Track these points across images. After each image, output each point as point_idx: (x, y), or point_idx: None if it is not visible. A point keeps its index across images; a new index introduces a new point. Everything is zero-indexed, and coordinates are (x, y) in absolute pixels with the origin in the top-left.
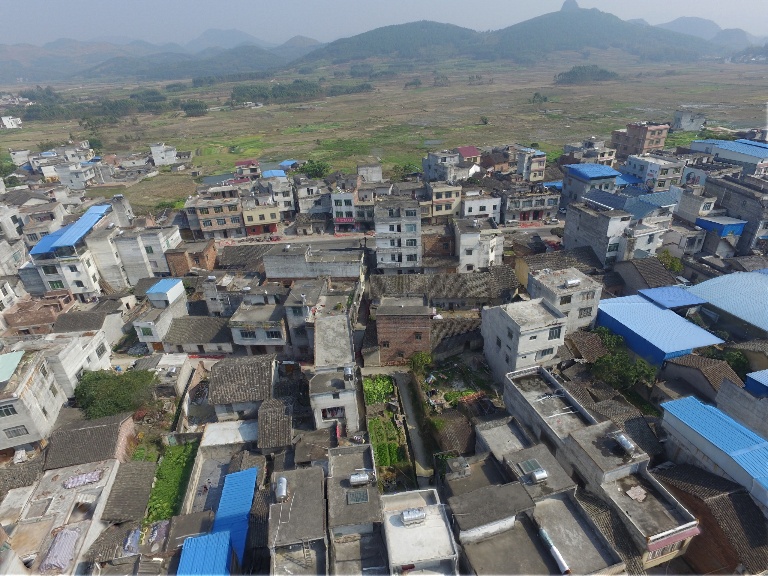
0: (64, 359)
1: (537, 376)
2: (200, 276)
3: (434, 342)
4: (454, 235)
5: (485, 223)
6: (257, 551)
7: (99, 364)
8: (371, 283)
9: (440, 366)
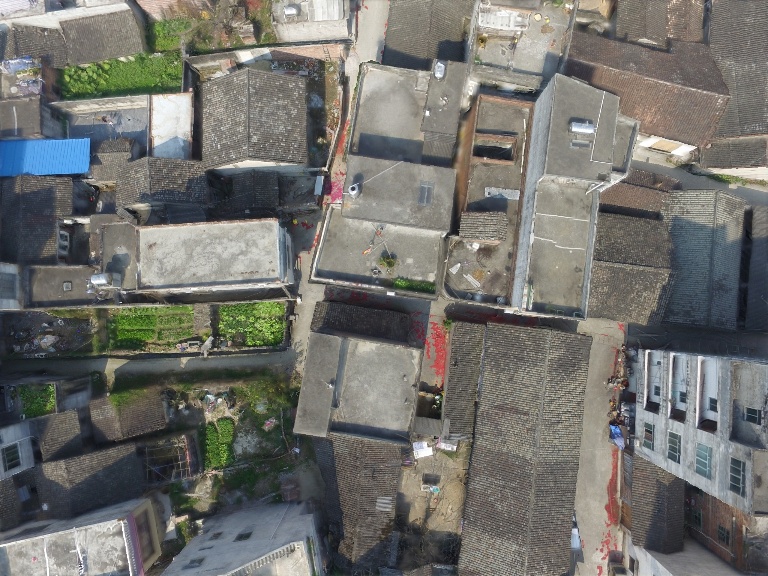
0: None
1: (127, 567)
2: None
3: None
4: (758, 574)
5: None
6: (1, 190)
7: None
8: (527, 330)
9: None
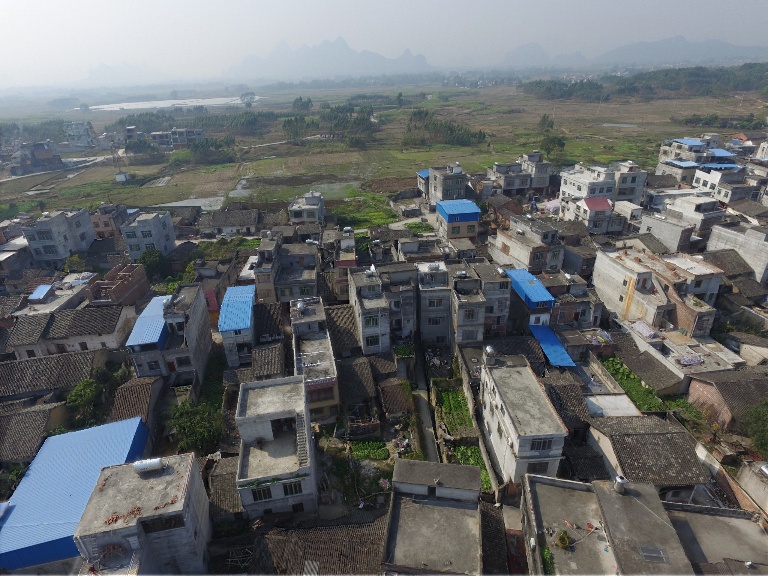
0: None
1: None
2: None
3: None
4: None
5: None
6: None
7: None
8: None
9: None
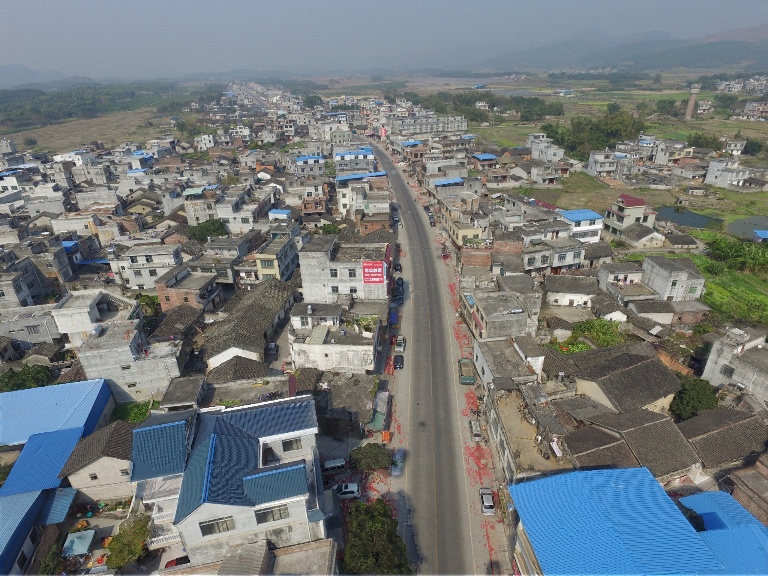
0: (219, 208)
1: None
2: (347, 234)
3: (169, 311)
4: None
5: (363, 342)
6: None
7: (241, 225)
8: None
9: (153, 321)
